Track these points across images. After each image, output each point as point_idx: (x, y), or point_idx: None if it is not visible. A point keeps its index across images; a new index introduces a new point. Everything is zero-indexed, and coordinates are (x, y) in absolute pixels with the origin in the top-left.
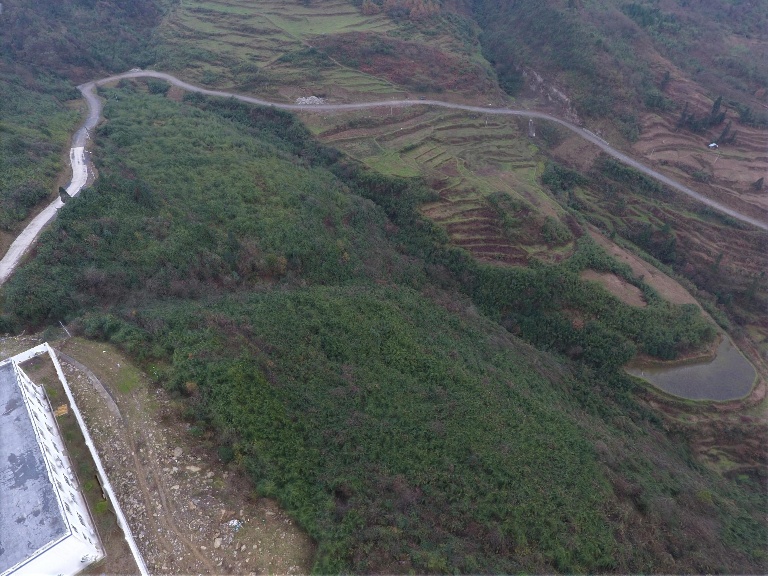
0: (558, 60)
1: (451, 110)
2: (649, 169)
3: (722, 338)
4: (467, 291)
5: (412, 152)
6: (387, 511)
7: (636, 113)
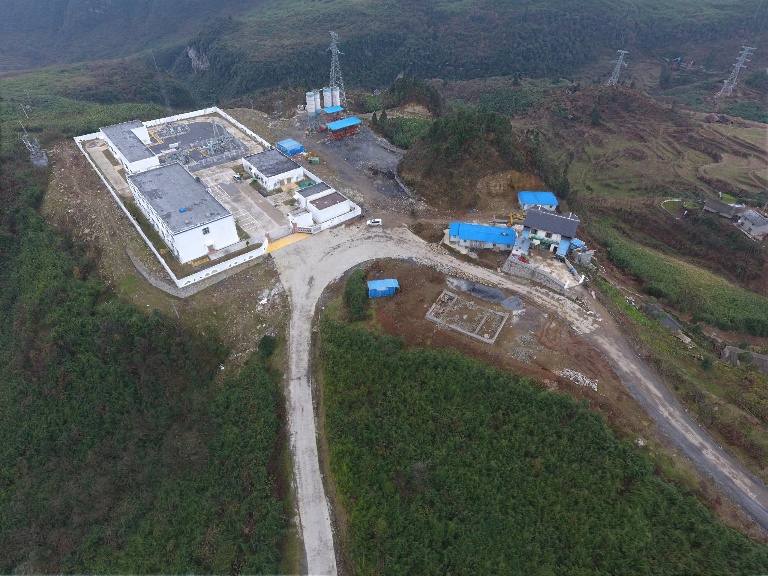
0: None
1: None
2: None
3: None
4: None
5: None
6: None
7: None
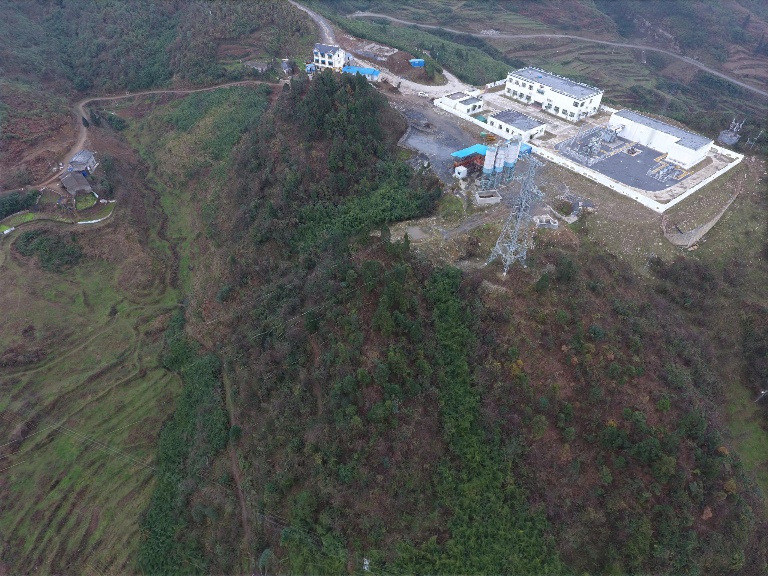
0: (664, 8)
1: (587, 42)
2: (735, 80)
3: None
4: None
5: (568, 65)
6: None
7: (725, 43)
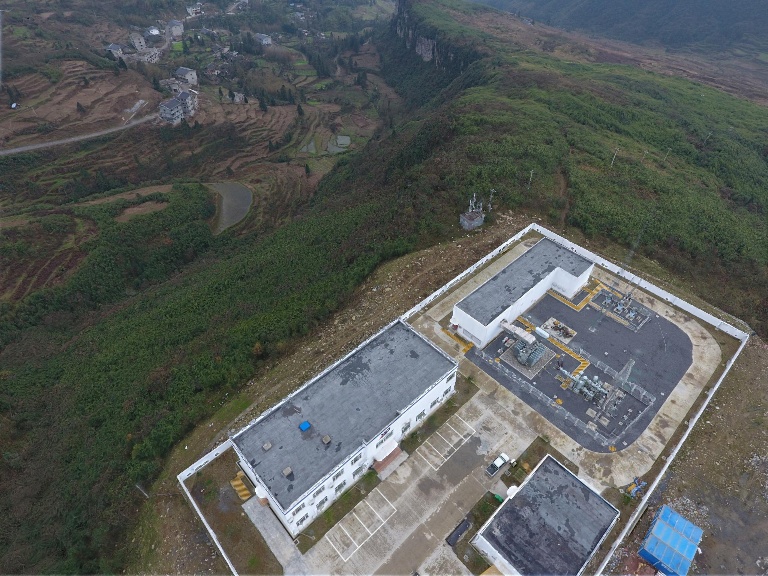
0: None
1: None
2: (5, 151)
3: None
4: (90, 307)
5: None
6: (363, 239)
7: None
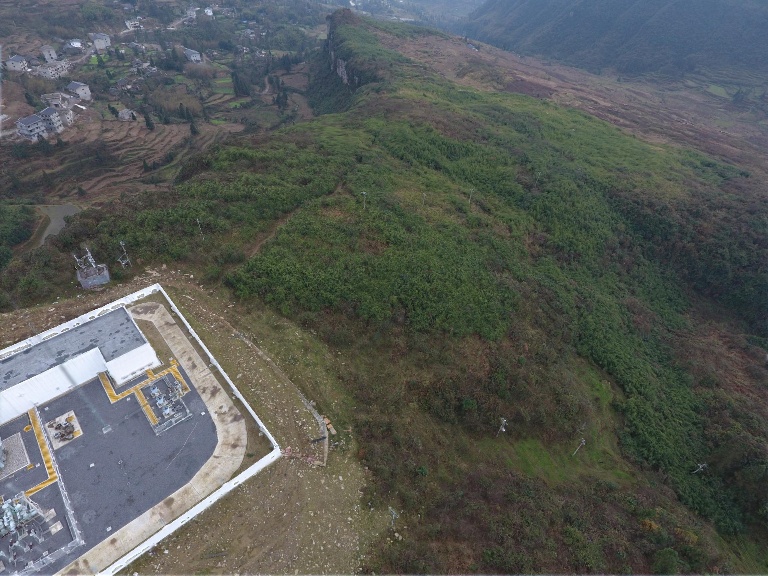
0: None
1: None
2: None
3: (37, 208)
4: None
5: None
6: None
7: None
